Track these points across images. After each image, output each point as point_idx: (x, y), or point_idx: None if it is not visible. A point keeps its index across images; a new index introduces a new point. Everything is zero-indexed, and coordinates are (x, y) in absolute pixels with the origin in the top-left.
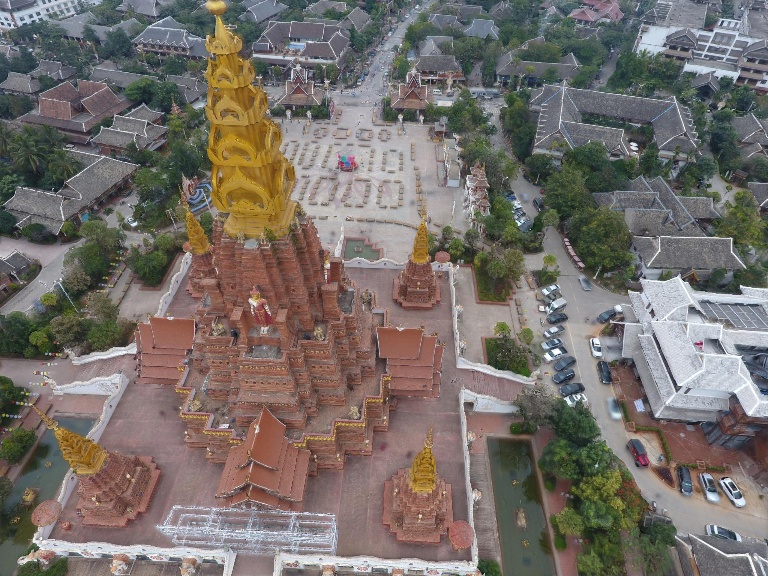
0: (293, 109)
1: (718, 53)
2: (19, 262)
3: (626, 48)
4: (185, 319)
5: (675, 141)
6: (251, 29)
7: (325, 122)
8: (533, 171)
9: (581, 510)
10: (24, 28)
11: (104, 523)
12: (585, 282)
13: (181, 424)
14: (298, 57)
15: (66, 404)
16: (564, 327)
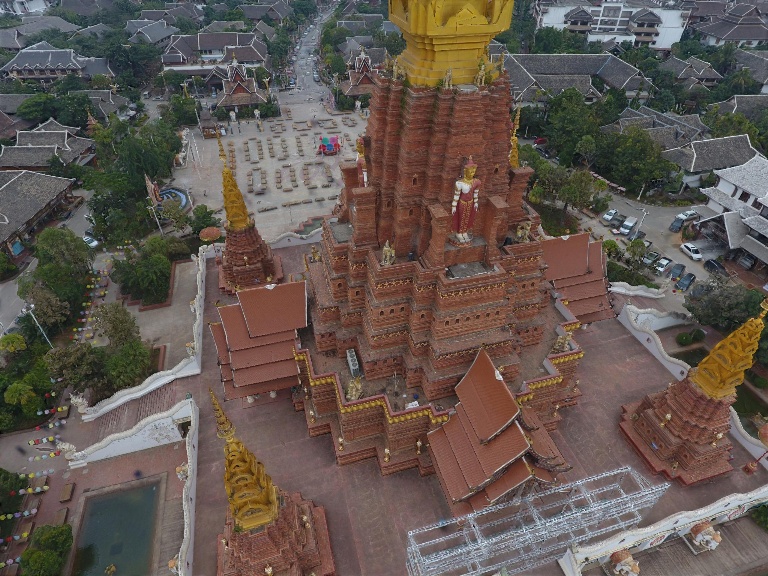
0: (235, 111)
1: (609, 25)
2: None
3: (530, 31)
4: (292, 283)
5: (632, 81)
6: (149, 48)
7: (277, 119)
8: (524, 123)
9: None
10: None
11: None
12: (633, 204)
13: (310, 441)
14: (219, 65)
15: (98, 476)
16: (650, 241)
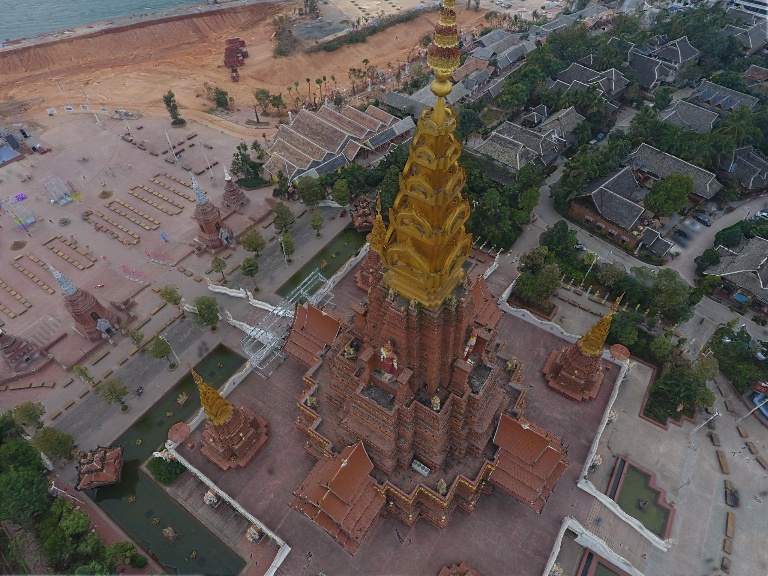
0: None
1: None
2: (660, 248)
3: None
4: None
5: None
6: None
7: None
8: None
9: (113, 572)
10: None
11: None
12: None
13: None
14: None
15: (481, 269)
16: None
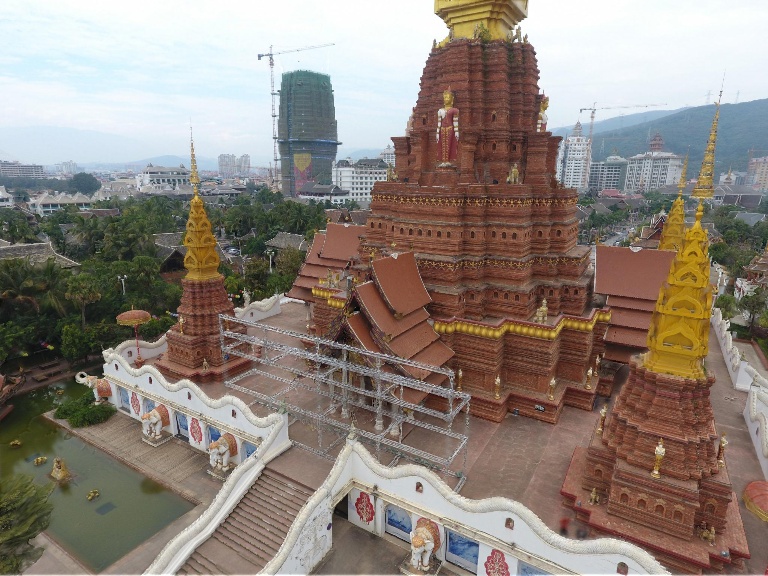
0: None
1: None
2: None
3: None
4: None
5: None
6: None
7: None
8: None
9: None
10: (334, 205)
11: (173, 368)
12: None
13: None
14: None
15: None
16: None
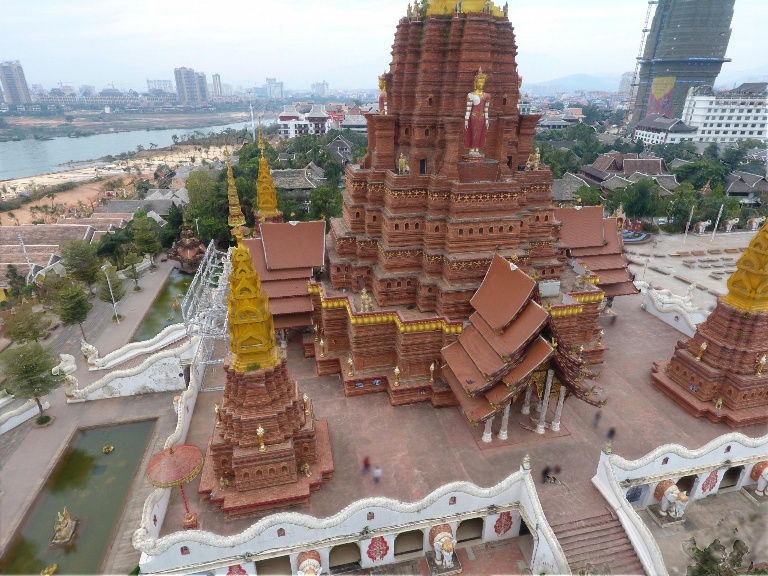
0: None
1: None
2: None
3: None
4: None
5: None
6: None
7: None
8: None
9: None
10: None
11: None
12: None
13: None
14: None
15: None
16: None
